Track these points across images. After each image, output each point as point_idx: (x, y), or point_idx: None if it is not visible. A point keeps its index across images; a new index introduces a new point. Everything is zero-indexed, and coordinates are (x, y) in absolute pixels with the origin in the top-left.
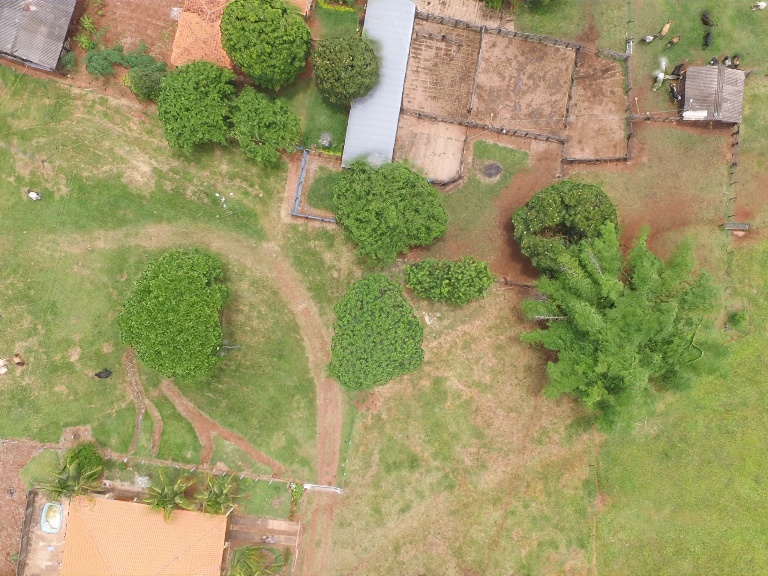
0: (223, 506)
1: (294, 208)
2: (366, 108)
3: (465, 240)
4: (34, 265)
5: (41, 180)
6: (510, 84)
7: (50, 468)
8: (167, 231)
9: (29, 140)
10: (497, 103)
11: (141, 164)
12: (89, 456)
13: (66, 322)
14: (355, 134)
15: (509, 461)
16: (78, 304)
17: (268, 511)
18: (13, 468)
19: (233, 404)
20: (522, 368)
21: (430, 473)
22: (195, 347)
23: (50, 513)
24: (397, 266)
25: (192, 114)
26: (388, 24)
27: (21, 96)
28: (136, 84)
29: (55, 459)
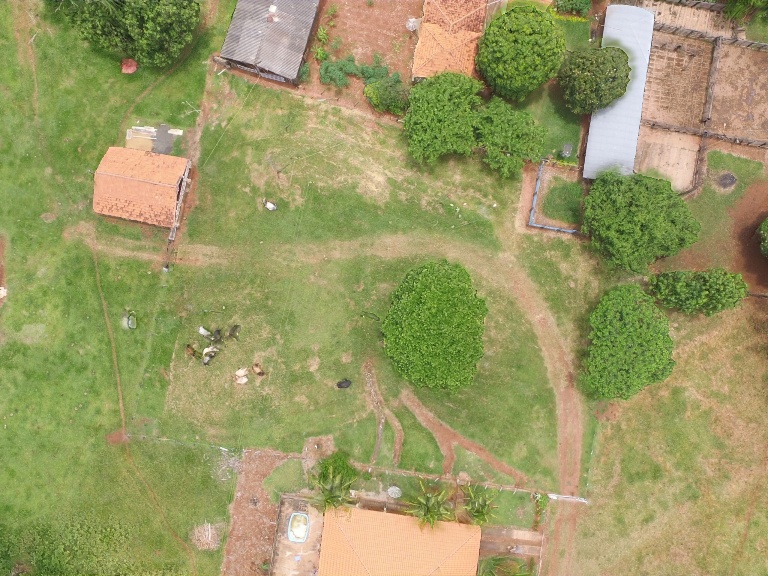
0: (487, 517)
1: (529, 218)
2: (607, 119)
3: (700, 250)
4: (271, 275)
5: (276, 190)
6: (743, 94)
7: (295, 478)
8: (402, 241)
9: (263, 151)
10: (730, 113)
11: (375, 174)
12: (346, 466)
13: (304, 332)
14: (596, 145)
15: (751, 472)
16: (316, 314)
17: (513, 521)
18: (256, 478)
19: (473, 414)
20: (760, 378)
21: (673, 483)
22: (466, 359)
23: (294, 523)
24: (633, 276)
25: (445, 125)
26: (628, 35)
27: (254, 107)
28: (379, 95)
29: (299, 469)
